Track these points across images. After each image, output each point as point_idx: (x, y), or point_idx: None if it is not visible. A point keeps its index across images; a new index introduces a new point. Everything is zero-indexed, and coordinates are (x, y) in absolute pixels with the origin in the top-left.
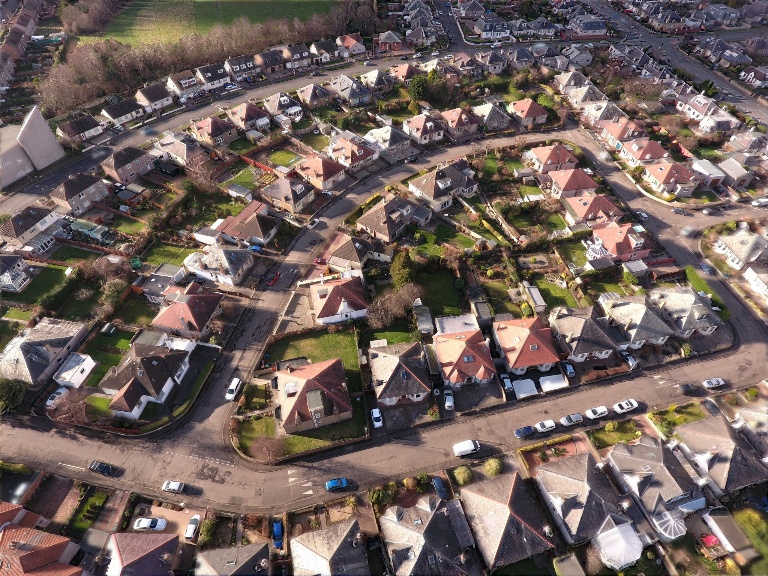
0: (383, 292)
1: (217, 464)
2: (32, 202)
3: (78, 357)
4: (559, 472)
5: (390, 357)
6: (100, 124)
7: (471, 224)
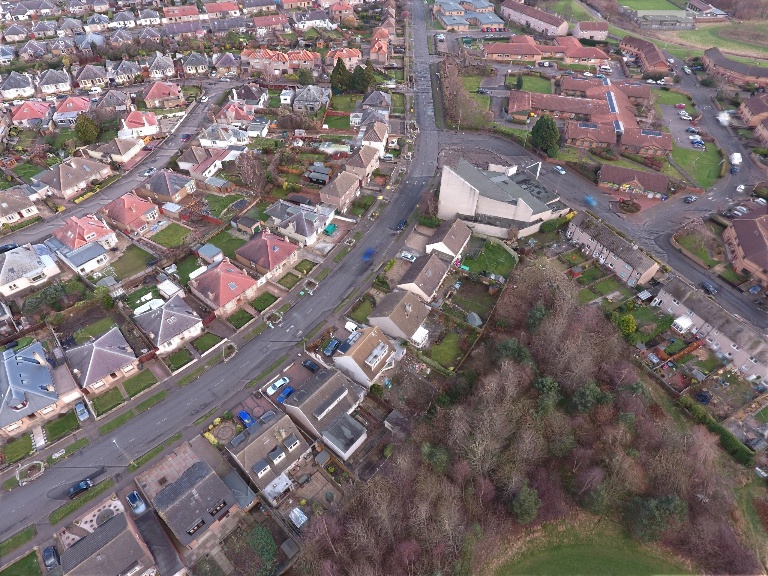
0: (109, 138)
1: (209, 85)
2: (412, 170)
3: (286, 95)
4: (58, 77)
5: (115, 94)
6: (432, 252)
7: (1, 183)
